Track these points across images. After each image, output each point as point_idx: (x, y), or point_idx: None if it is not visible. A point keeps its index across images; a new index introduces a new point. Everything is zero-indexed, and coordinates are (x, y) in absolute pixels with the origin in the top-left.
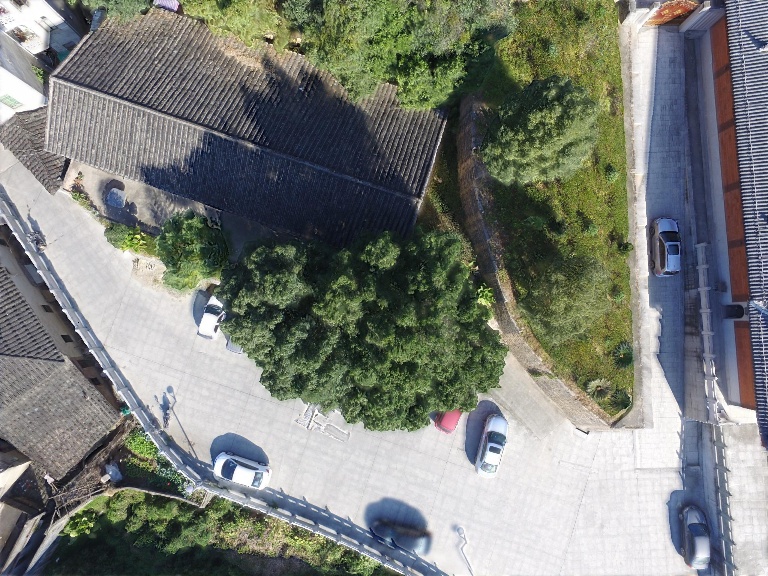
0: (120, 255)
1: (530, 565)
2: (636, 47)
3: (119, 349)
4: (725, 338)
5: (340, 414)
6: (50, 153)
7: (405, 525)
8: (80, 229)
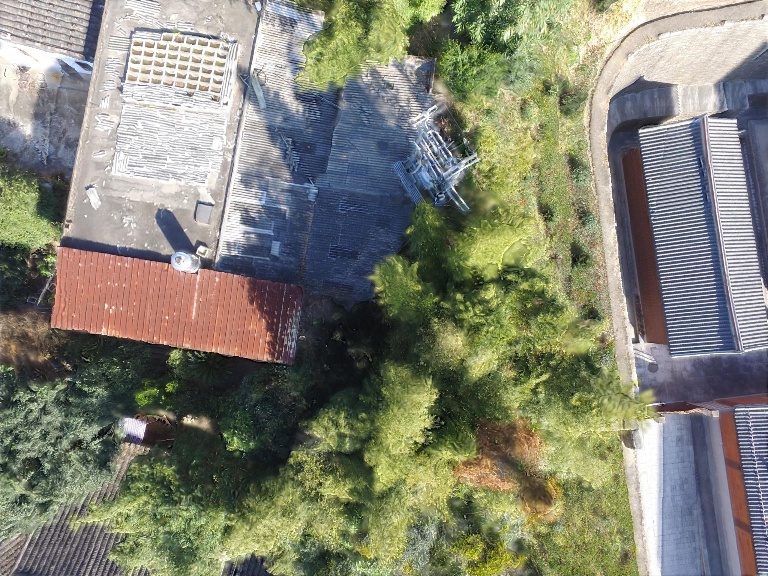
0: None
1: None
2: None
3: None
4: None
5: None
6: None
7: None
8: None
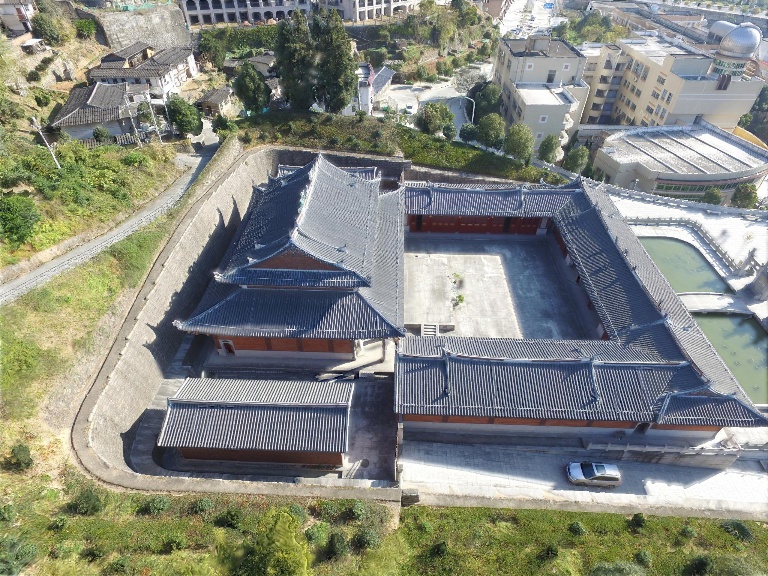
0: None
1: None
2: (425, 485)
3: None
4: (661, 435)
5: None
6: None
7: None
8: None
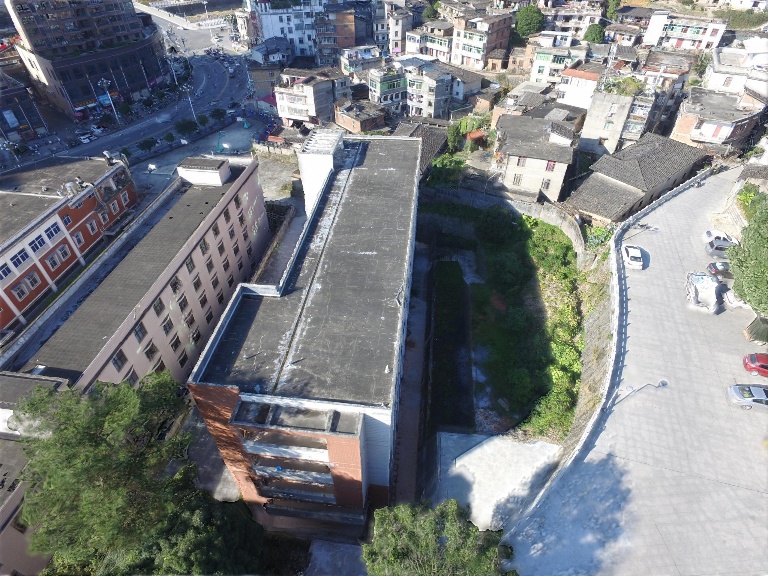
0: (717, 209)
1: (667, 441)
2: None
3: (664, 210)
4: None
5: (714, 293)
6: (760, 177)
7: (646, 344)
8: (716, 197)
